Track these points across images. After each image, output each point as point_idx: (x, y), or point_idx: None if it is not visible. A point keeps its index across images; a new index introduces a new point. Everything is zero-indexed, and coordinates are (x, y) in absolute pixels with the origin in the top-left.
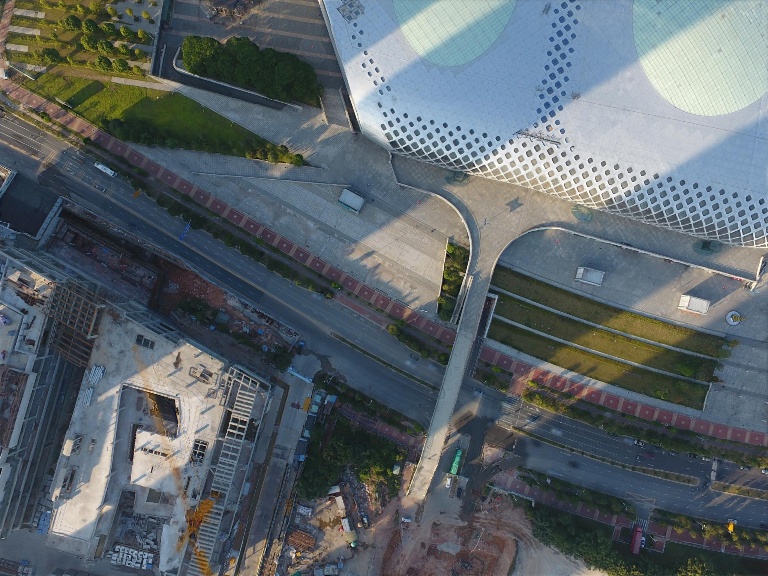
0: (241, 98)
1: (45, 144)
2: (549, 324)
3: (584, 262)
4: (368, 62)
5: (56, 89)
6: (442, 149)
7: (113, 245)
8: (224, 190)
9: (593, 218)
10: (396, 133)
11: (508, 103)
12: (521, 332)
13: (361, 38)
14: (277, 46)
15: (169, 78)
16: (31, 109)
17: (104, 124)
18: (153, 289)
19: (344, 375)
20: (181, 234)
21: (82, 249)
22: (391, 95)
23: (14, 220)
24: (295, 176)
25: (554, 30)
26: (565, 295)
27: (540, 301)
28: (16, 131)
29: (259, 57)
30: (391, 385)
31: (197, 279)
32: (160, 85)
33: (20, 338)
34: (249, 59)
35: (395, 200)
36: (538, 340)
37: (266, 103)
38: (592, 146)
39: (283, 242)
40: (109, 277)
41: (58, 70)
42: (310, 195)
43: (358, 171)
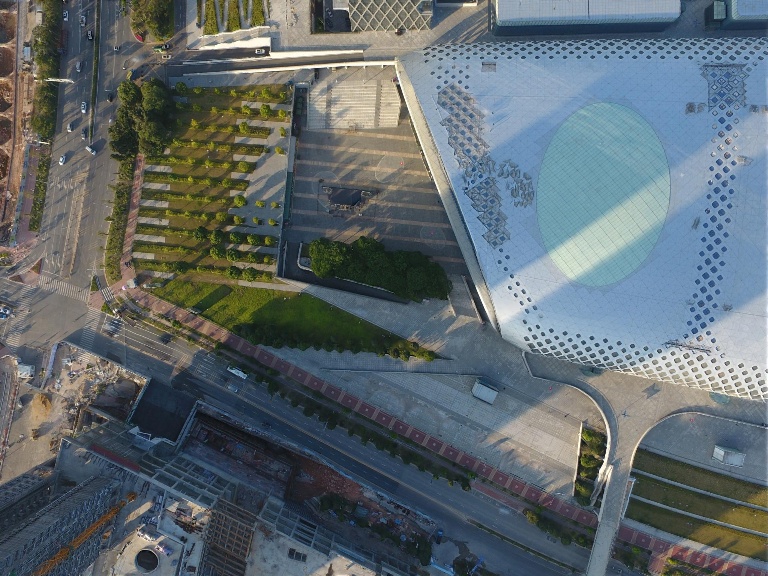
0: (367, 293)
1: (176, 348)
2: (687, 502)
3: (721, 439)
4: (514, 284)
5: (184, 295)
6: (586, 356)
7: (246, 440)
8: (354, 384)
9: (732, 401)
10: (539, 344)
11: (658, 317)
12: (659, 511)
13: (507, 262)
14: (397, 235)
15: (292, 274)
16: (161, 316)
17: (236, 331)
18: (288, 482)
19: (482, 560)
20: (314, 430)
21: (215, 444)
22: (537, 313)
23: (152, 426)
24: (425, 368)
25: (704, 244)
26: (703, 473)
27: (677, 480)
28: (147, 337)
29: (390, 263)
30: (530, 568)
31: (333, 474)
32: (287, 286)
33: (182, 566)
34: (380, 265)
35: (526, 387)
36: (676, 518)
37: (393, 298)
38: (744, 353)
39: (415, 432)
40: (244, 472)
41: (185, 276)
42: (441, 386)
43: (488, 360)
